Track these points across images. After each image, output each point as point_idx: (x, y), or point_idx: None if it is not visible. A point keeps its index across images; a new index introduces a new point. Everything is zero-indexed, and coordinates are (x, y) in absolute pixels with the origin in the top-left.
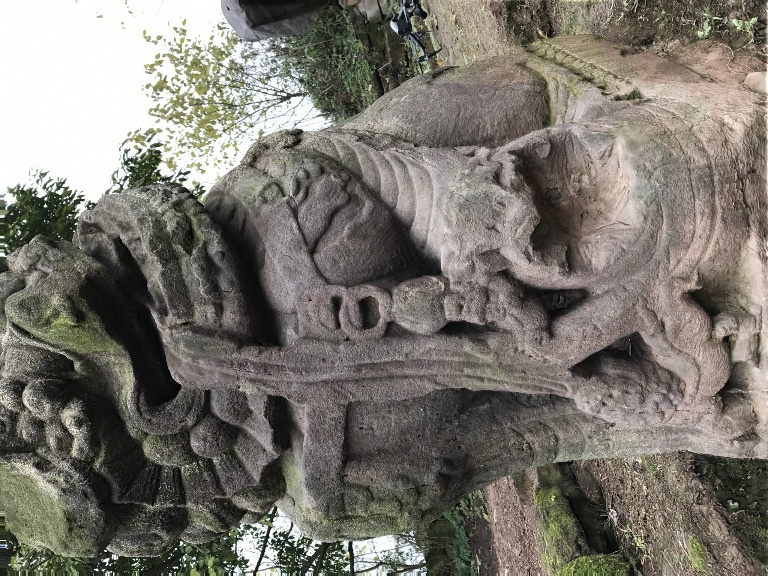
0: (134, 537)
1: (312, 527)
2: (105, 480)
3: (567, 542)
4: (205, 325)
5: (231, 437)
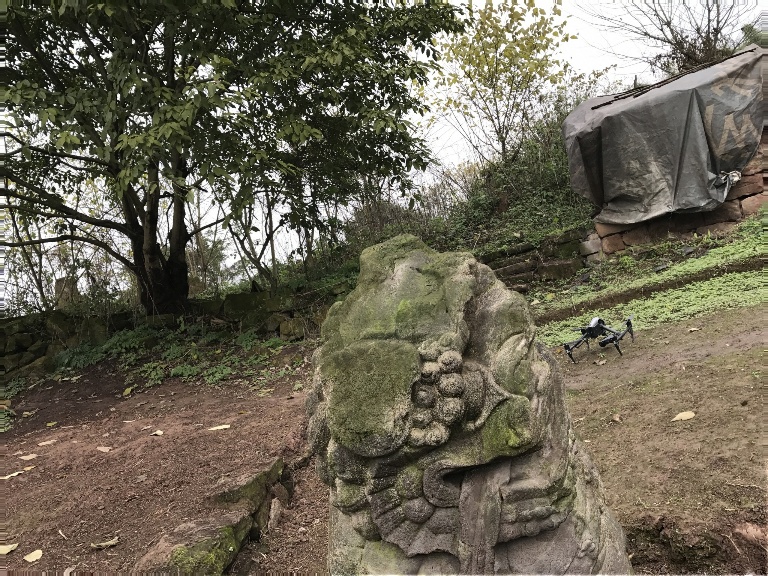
0: (343, 460)
1: (349, 570)
2: (394, 454)
3: (203, 574)
4: (502, 513)
5: (418, 522)
